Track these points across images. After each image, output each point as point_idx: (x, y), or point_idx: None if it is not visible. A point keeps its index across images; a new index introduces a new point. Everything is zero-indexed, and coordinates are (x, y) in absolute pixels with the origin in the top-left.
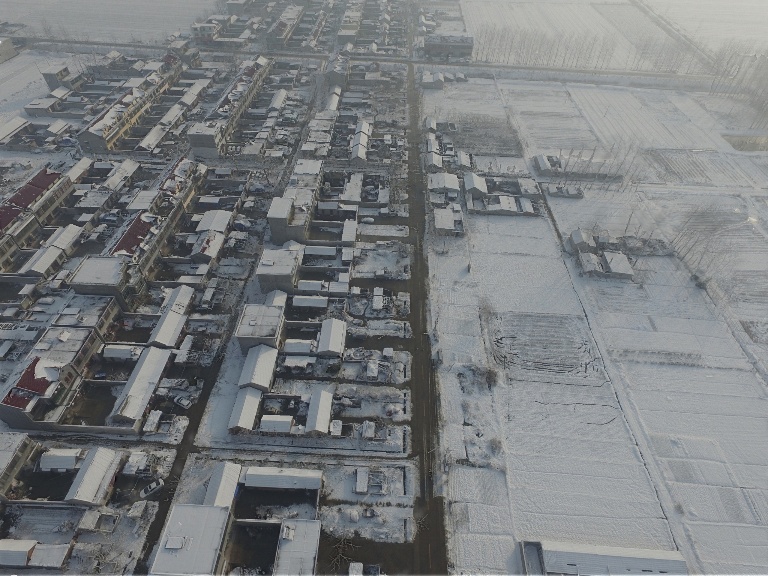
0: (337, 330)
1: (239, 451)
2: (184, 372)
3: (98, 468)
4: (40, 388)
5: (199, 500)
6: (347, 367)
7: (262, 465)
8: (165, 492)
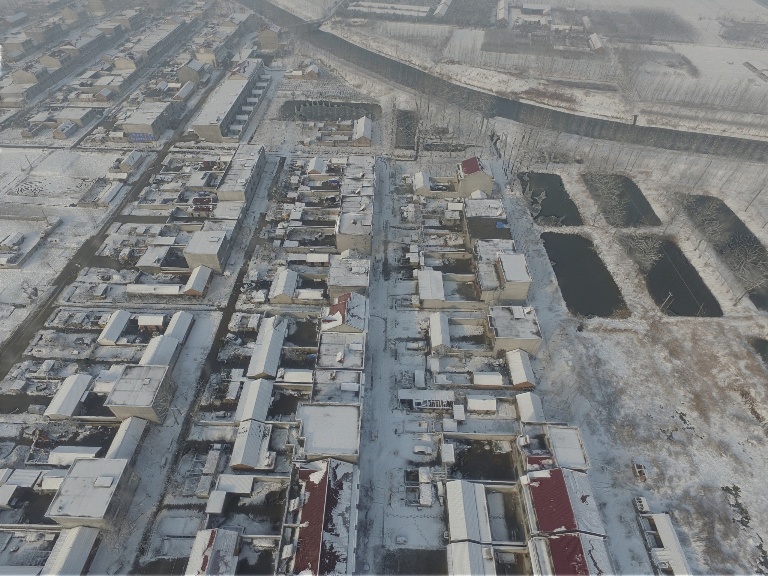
0: (59, 400)
1: (188, 309)
2: (237, 367)
3: (280, 285)
4: (333, 308)
5: (217, 284)
6: (72, 374)
7: (172, 301)
8: (240, 287)
